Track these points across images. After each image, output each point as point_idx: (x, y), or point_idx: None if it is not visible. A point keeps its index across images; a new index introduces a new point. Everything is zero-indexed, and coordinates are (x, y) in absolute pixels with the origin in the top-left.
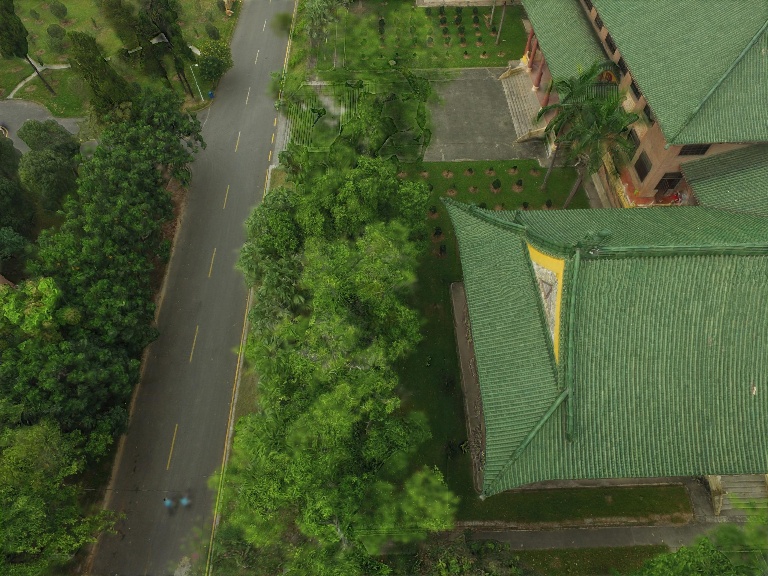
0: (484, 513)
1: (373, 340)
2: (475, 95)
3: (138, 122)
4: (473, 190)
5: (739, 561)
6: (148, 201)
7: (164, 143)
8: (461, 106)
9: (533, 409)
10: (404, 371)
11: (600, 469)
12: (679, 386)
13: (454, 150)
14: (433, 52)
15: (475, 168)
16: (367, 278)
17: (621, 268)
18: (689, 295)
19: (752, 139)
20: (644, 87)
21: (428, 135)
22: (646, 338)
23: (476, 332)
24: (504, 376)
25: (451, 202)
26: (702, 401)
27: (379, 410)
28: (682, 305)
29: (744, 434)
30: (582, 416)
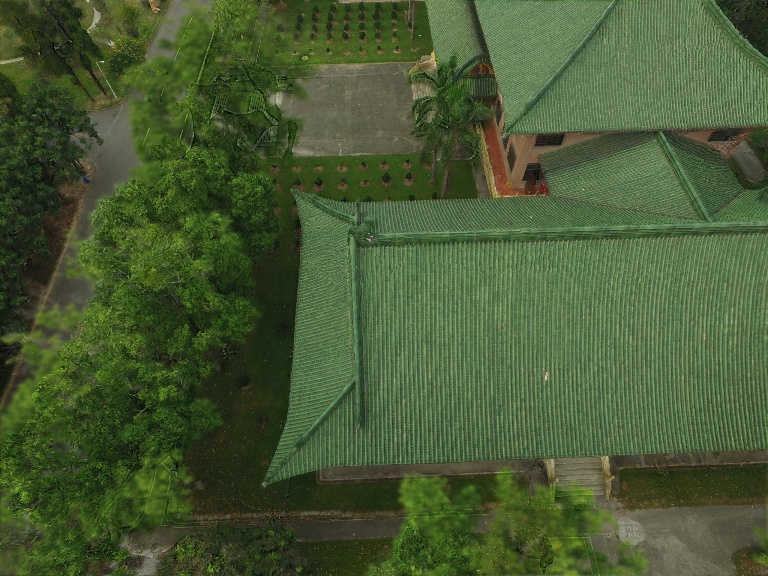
0: (322, 503)
1: (176, 330)
2: (382, 90)
3: (17, 118)
4: (364, 184)
5: (567, 547)
6: (25, 197)
7: (41, 139)
8: (367, 101)
9: (328, 397)
10: (265, 363)
11: (390, 455)
12: (471, 372)
13: (352, 144)
14: (347, 47)
15: (370, 162)
16: (143, 267)
17: (402, 255)
18: (475, 281)
19: (593, 128)
20: (500, 78)
21: (293, 128)
22: (436, 325)
23: (298, 322)
24: (312, 365)
25: (298, 194)
26: (494, 387)
27: (154, 398)
28: (469, 291)
29: (535, 419)
30: (374, 403)
